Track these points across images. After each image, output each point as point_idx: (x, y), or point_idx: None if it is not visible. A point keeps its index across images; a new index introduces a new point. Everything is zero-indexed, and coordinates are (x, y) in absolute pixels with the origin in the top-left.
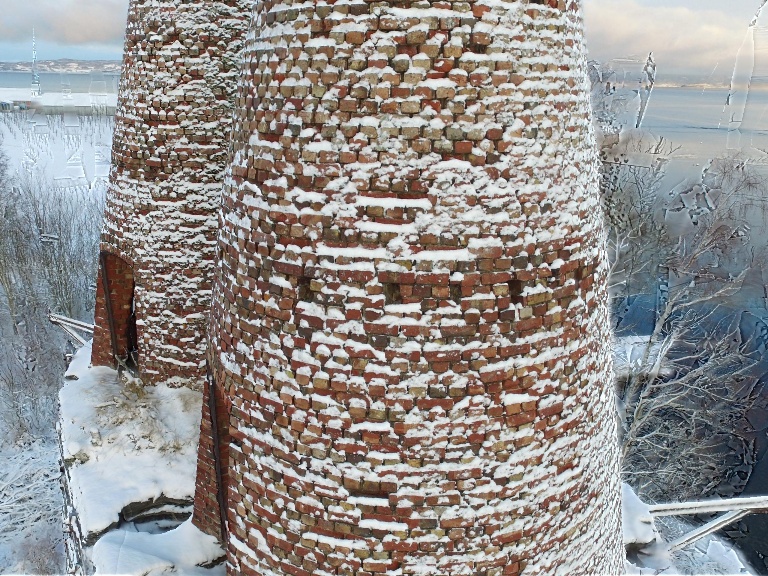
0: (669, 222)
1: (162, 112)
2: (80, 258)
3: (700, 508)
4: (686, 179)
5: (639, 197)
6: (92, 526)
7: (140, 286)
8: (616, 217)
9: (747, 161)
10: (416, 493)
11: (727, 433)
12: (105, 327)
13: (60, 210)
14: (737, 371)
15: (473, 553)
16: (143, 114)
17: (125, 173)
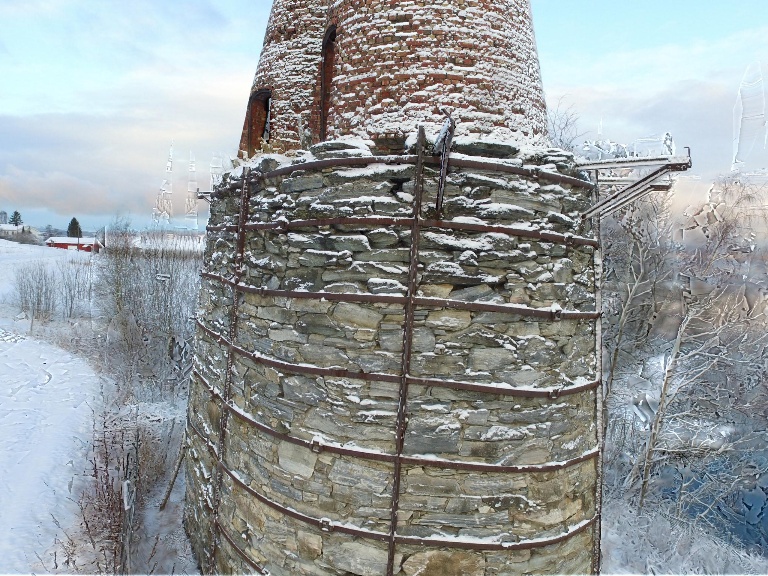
0: (687, 241)
1: (298, 2)
2: (185, 292)
3: (618, 182)
4: (696, 202)
5: (655, 214)
6: (247, 165)
7: (275, 100)
8: (637, 233)
9: (741, 173)
10: (422, 18)
11: (763, 431)
12: (245, 150)
13: (175, 253)
14: (752, 342)
15: (448, 48)
16: (287, 6)
17: (272, 42)
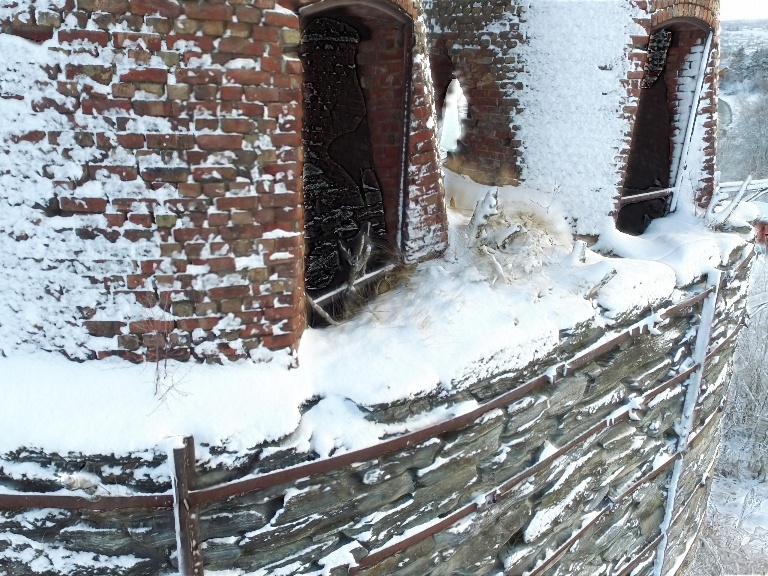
0: None
1: None
2: None
3: None
4: None
5: None
6: None
7: None
8: None
9: None
10: None
11: None
12: (301, 228)
13: None
14: None
15: None
16: None
17: None
